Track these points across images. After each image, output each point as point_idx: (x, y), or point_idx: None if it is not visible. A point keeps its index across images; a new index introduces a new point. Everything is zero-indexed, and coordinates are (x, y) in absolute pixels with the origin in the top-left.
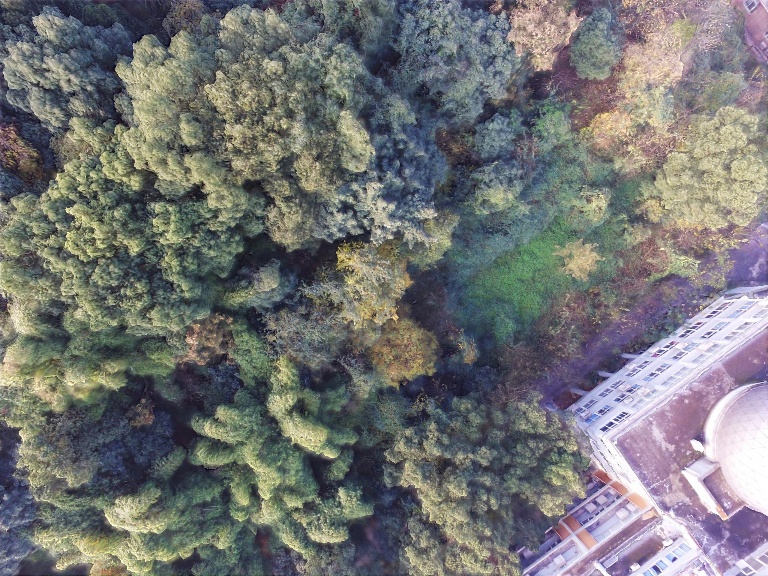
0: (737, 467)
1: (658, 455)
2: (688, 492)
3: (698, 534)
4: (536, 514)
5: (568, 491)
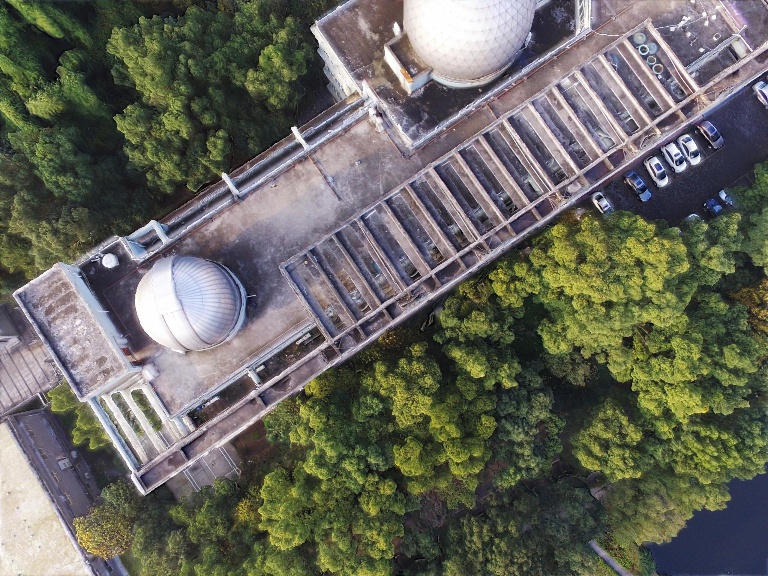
0: (405, 10)
1: (362, 43)
2: (390, 77)
3: (398, 115)
4: (263, 123)
5: (279, 80)
